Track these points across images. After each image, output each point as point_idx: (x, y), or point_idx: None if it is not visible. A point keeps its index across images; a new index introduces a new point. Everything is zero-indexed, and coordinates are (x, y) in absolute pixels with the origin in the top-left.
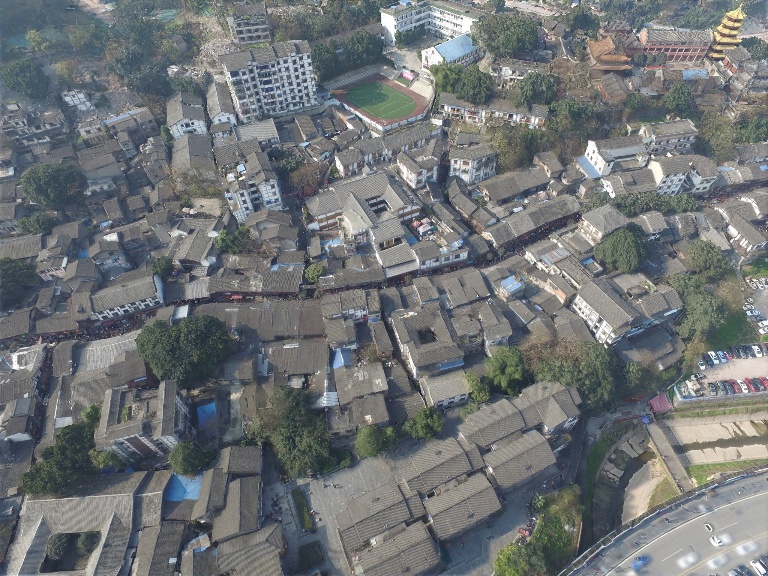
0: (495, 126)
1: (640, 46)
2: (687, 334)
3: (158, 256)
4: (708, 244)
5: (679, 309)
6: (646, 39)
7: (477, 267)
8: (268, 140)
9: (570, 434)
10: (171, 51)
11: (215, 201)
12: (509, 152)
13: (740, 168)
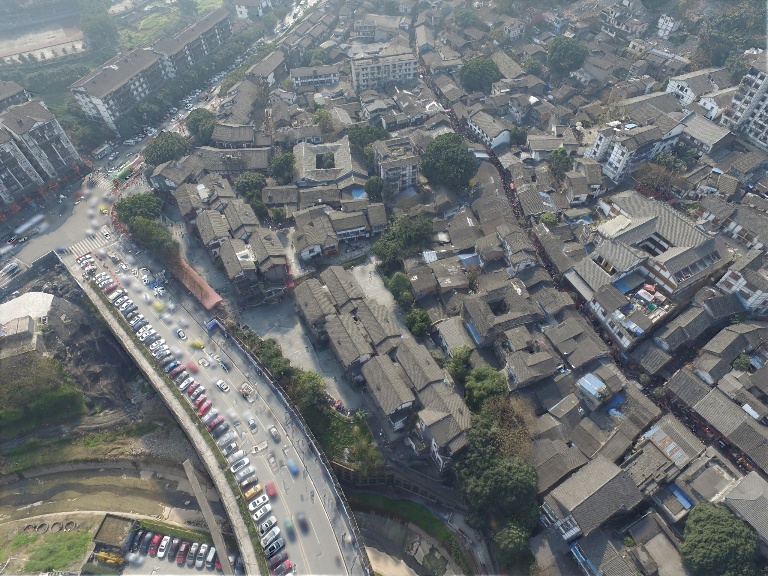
0: None
1: None
2: None
3: None
4: None
5: None
6: None
7: (625, 369)
8: (702, 143)
9: (440, 476)
10: None
11: None
12: None
13: None
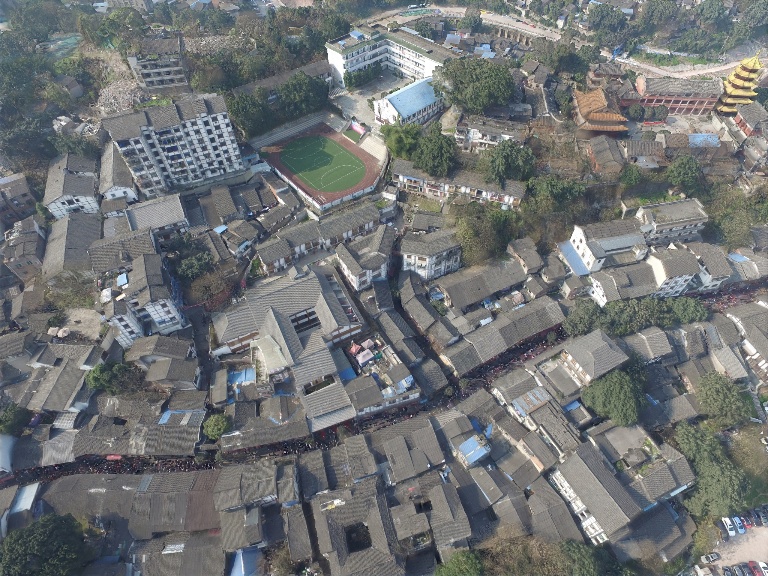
0: (461, 203)
1: (637, 97)
2: (699, 513)
3: (14, 395)
4: (724, 384)
5: (689, 484)
6: (644, 89)
7: (433, 404)
8: (173, 224)
9: None
10: (59, 98)
11: (97, 313)
12: (476, 246)
13: (756, 258)
